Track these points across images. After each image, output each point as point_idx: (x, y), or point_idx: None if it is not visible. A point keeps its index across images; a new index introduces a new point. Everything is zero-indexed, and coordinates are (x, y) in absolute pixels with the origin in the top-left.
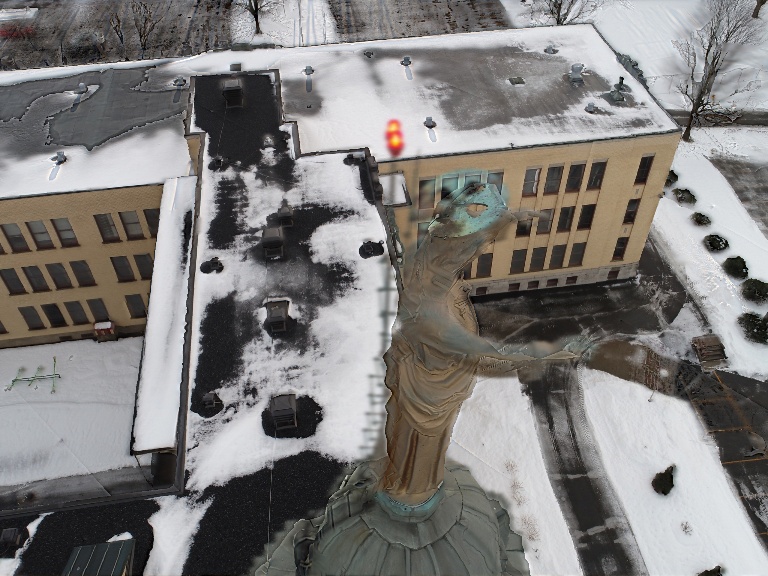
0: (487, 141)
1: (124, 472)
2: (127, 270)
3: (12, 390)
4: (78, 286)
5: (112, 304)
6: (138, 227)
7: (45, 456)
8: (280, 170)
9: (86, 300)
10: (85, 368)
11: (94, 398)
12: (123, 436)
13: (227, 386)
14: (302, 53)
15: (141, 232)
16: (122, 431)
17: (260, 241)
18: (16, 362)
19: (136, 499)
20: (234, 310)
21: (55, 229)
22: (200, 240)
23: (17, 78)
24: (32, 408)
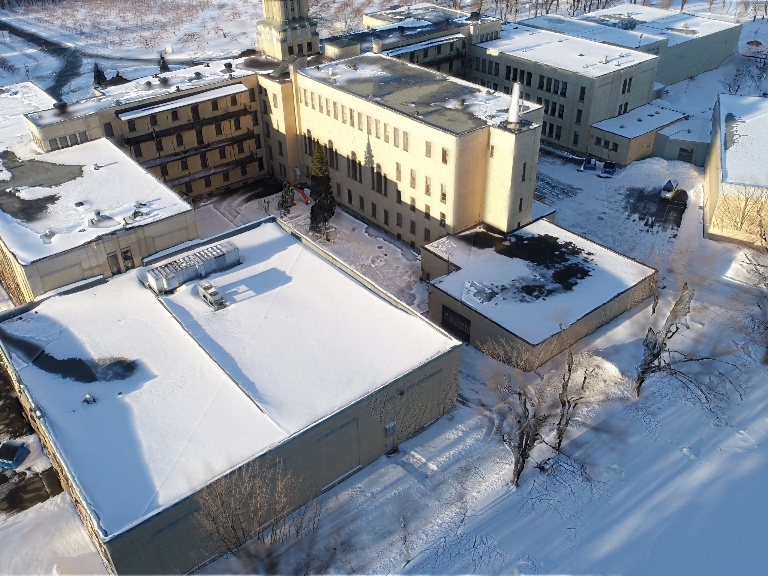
0: (49, 103)
1: None
2: None
3: None
4: None
5: None
6: None
7: None
8: None
9: None
10: None
11: None
12: None
13: None
14: None
15: None
16: None
17: None
18: None
19: None
20: None
21: None
22: None
23: None
24: None
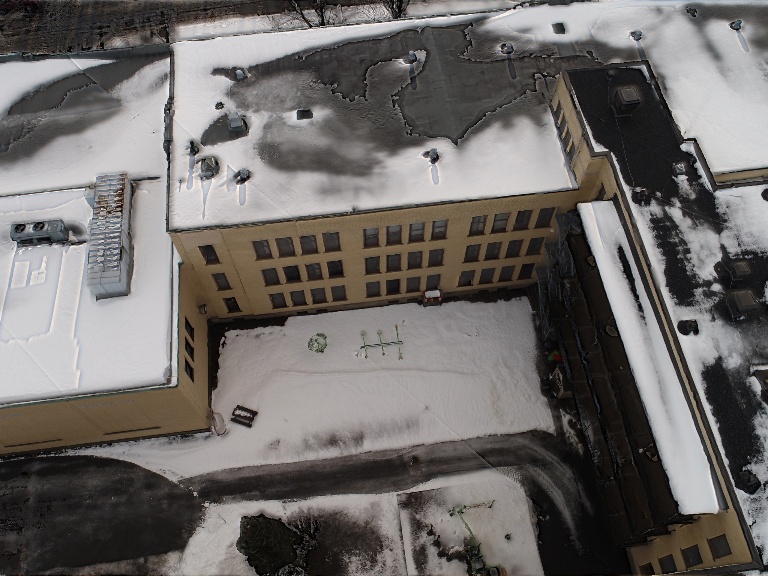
0: None
1: (491, 440)
2: (473, 252)
3: (363, 355)
4: (426, 266)
5: (447, 278)
6: (503, 222)
7: (416, 422)
8: (703, 205)
9: (427, 276)
10: (421, 334)
11: (442, 366)
12: (480, 405)
13: (755, 462)
14: (621, 8)
15: (504, 226)
16: (478, 400)
17: (719, 297)
18: (355, 326)
19: (729, 573)
20: (728, 379)
21: (432, 227)
22: (665, 295)
23: (335, 38)
24: (389, 375)
